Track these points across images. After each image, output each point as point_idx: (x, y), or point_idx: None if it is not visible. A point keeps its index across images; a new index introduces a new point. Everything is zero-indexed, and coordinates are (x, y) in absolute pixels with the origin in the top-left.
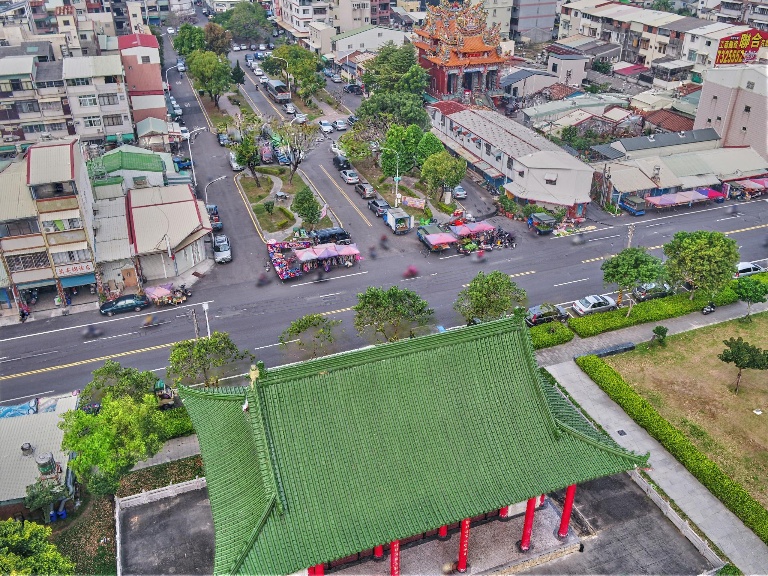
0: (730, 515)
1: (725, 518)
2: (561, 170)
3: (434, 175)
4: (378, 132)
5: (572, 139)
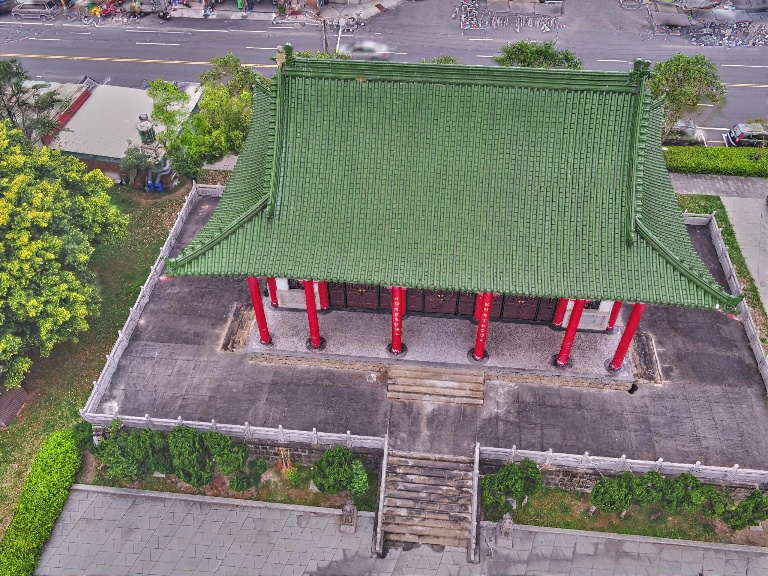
0: None
1: None
2: None
3: None
4: None
5: None
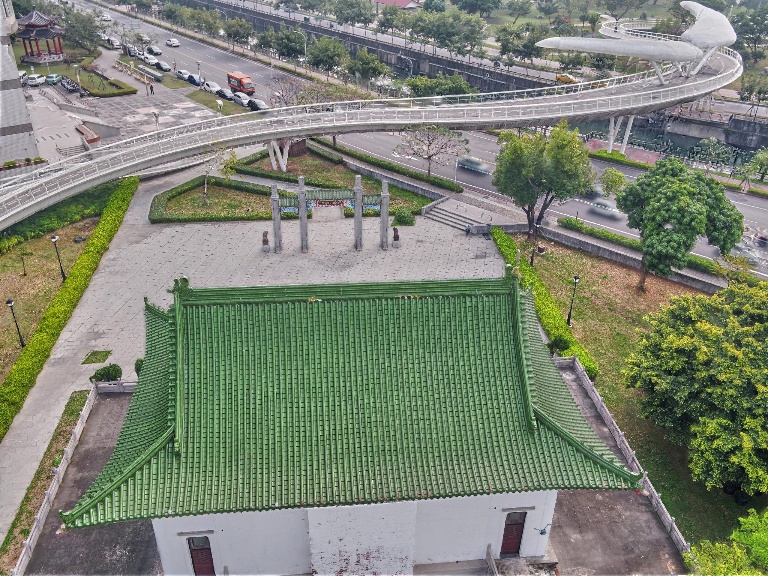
0: None
1: (5, 461)
2: None
3: None
4: None
5: None
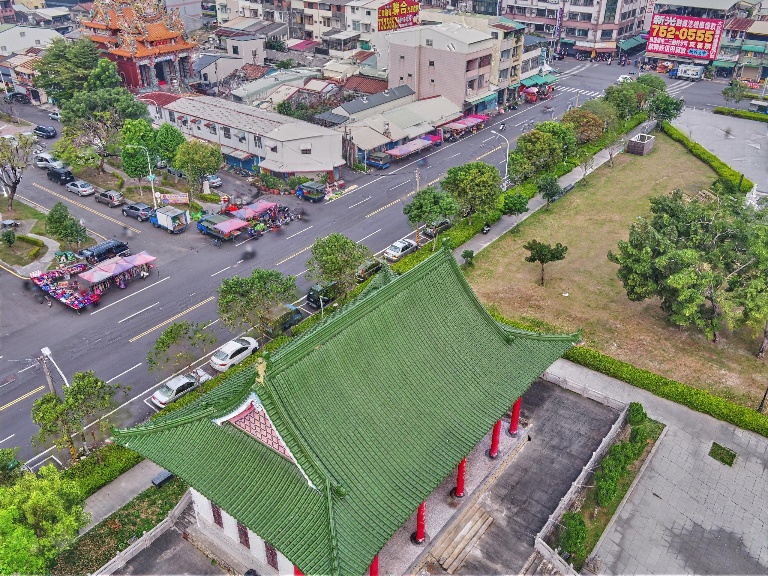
0: (596, 373)
1: (594, 377)
2: (314, 138)
3: (192, 165)
4: (97, 134)
5: (288, 113)
